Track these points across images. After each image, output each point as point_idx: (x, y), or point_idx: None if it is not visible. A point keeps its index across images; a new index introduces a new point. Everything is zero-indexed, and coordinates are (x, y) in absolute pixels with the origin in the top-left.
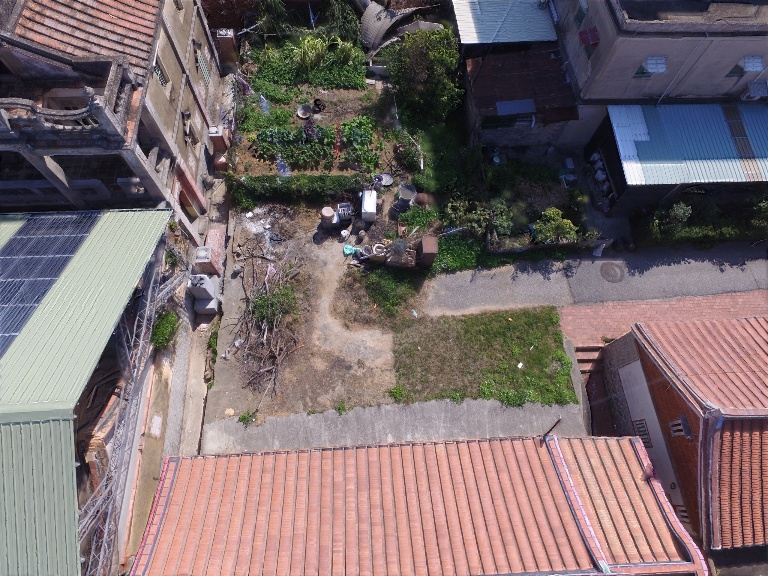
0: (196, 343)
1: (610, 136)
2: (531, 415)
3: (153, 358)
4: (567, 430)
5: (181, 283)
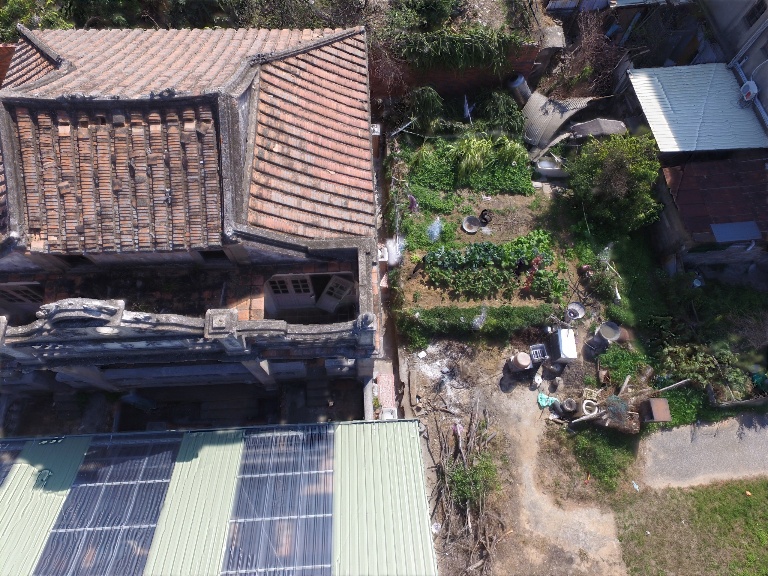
0: None
1: None
2: None
3: None
4: None
5: None
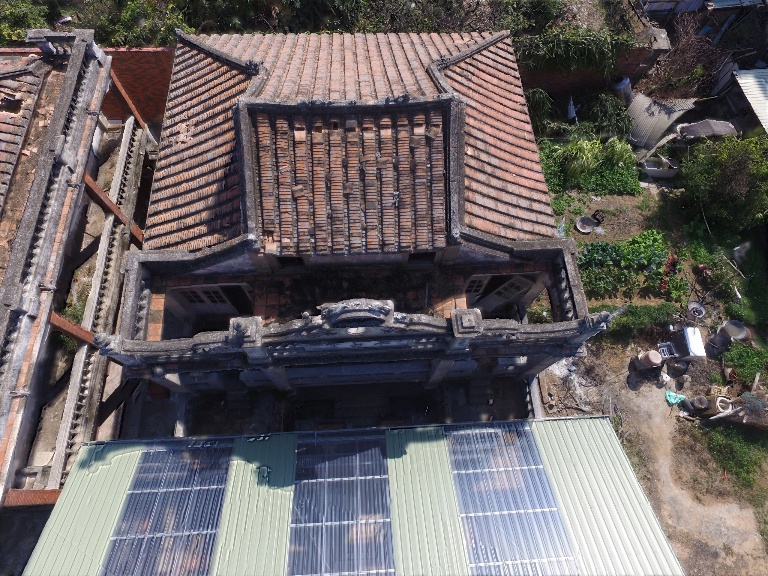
0: None
1: None
2: None
3: None
4: None
5: None
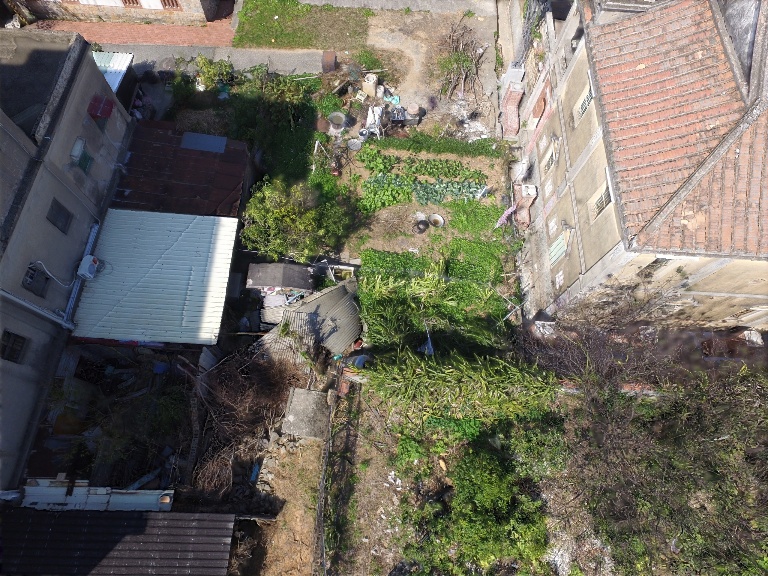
0: None
1: None
2: None
3: None
4: None
5: None
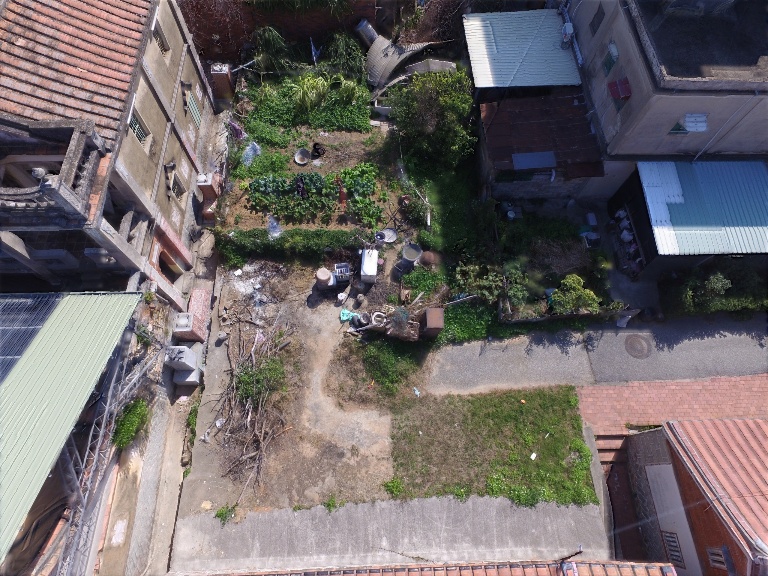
0: (174, 419)
1: (639, 196)
2: (545, 517)
3: (117, 456)
4: (586, 537)
5: (153, 366)
